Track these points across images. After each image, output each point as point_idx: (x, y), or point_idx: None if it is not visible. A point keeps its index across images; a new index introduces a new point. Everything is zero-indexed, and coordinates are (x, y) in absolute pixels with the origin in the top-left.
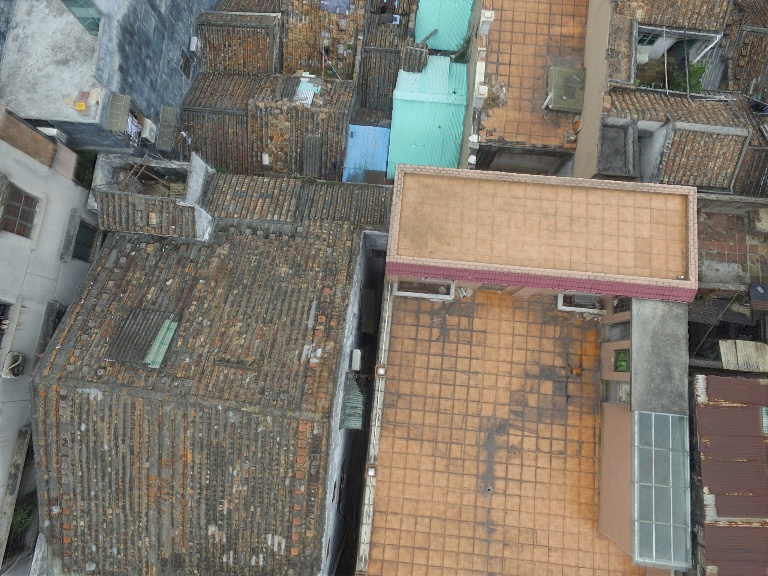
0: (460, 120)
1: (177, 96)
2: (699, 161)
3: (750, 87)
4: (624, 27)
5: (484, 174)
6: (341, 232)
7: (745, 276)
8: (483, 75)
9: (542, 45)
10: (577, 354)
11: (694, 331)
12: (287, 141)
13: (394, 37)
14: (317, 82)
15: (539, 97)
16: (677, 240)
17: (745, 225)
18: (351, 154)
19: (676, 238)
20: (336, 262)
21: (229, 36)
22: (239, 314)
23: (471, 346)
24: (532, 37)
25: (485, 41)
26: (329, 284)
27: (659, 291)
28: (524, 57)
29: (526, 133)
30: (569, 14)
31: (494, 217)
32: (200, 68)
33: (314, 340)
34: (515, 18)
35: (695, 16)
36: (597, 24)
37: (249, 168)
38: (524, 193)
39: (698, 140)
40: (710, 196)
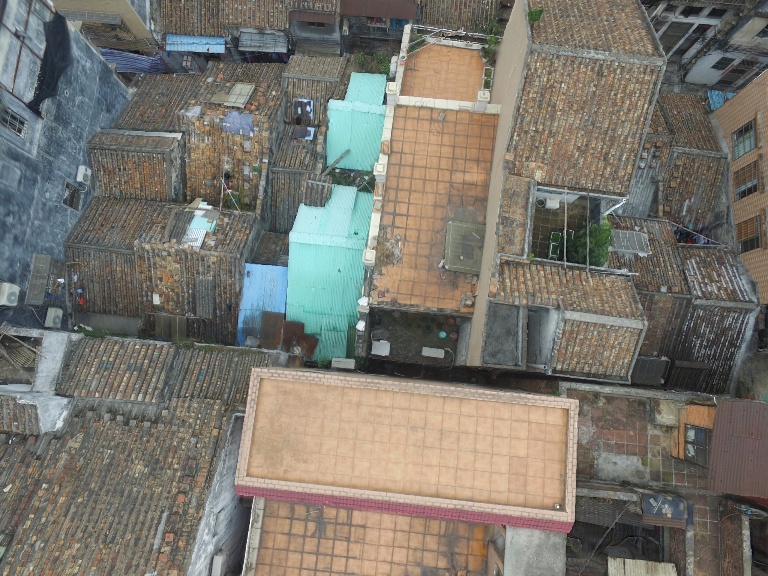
0: (361, 264)
1: (59, 234)
2: (593, 350)
3: (683, 208)
4: (521, 190)
5: (347, 381)
6: (210, 416)
7: (645, 471)
8: (377, 228)
9: (443, 194)
10: (463, 553)
11: (588, 533)
12: (177, 282)
13: (306, 155)
14: (212, 216)
15: (437, 253)
16: (556, 460)
17: (647, 412)
18: (248, 295)
19: (555, 457)
20: (198, 457)
21: (124, 160)
22: (78, 532)
23: (349, 543)
24: (433, 184)
25: (381, 189)
26: (185, 488)
27: (532, 522)
28: (423, 207)
29: (421, 294)
30: (473, 159)
31: (357, 430)
32: (95, 191)
33: (157, 567)
34: (415, 162)
35: (599, 177)
36: (495, 182)
37: (139, 307)
38: (392, 401)
39: (591, 329)
40: (604, 389)
